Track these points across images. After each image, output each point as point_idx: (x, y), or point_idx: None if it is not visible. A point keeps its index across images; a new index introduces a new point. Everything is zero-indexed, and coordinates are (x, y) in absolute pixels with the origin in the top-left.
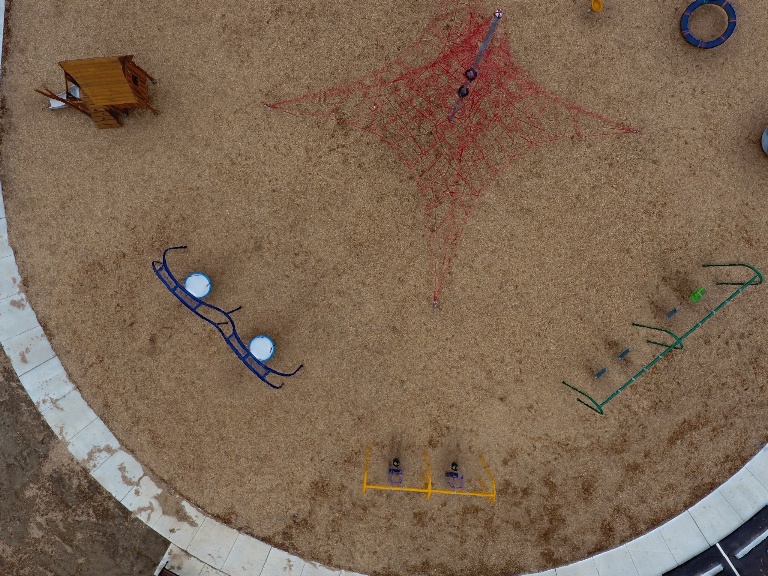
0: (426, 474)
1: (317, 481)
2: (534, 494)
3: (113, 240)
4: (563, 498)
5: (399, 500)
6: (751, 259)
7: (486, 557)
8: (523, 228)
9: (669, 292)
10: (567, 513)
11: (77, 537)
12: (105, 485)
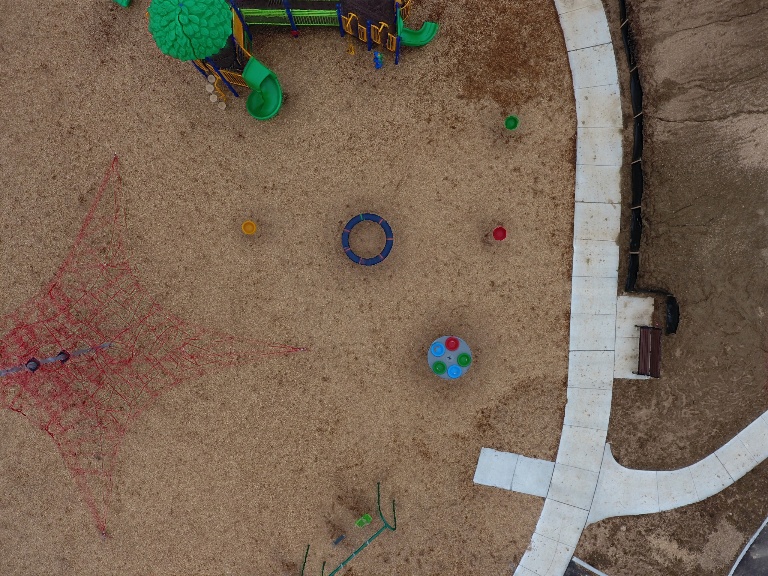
0: None
1: None
2: None
3: None
4: None
5: None
6: (429, 473)
7: None
8: (192, 452)
9: (345, 511)
10: None
11: None
12: None
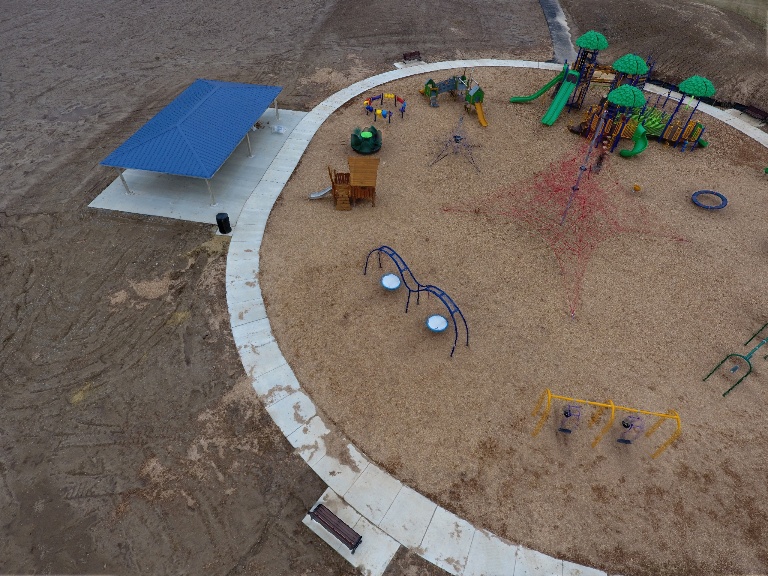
0: (595, 447)
1: (485, 441)
2: (717, 481)
3: (331, 258)
4: (751, 490)
5: (572, 470)
6: None
7: (689, 550)
8: (628, 279)
9: None
10: (764, 507)
11: (233, 466)
12: (276, 420)
